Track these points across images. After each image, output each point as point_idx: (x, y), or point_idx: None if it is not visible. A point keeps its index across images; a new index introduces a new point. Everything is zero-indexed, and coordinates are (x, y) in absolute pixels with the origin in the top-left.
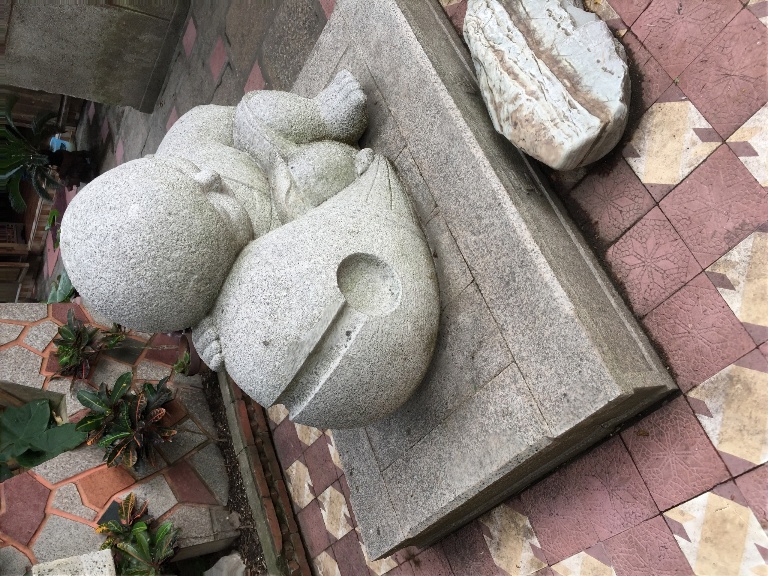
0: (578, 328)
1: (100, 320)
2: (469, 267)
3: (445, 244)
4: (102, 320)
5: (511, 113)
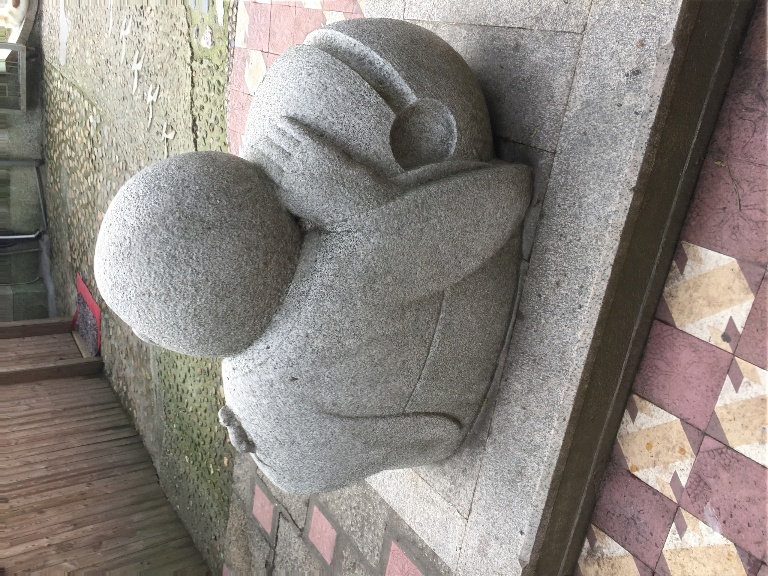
0: (366, 2)
1: None
2: None
3: None
4: None
5: None
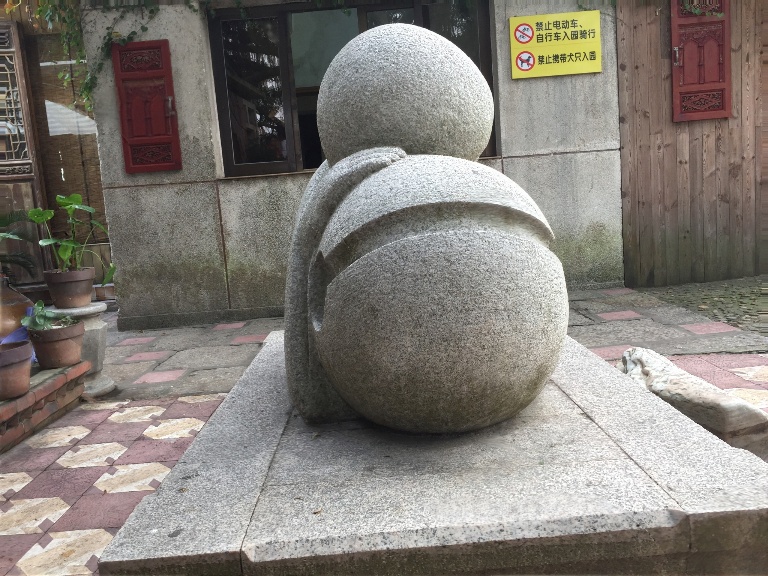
0: (755, 457)
1: None
2: (581, 407)
3: (550, 394)
4: None
5: (672, 379)
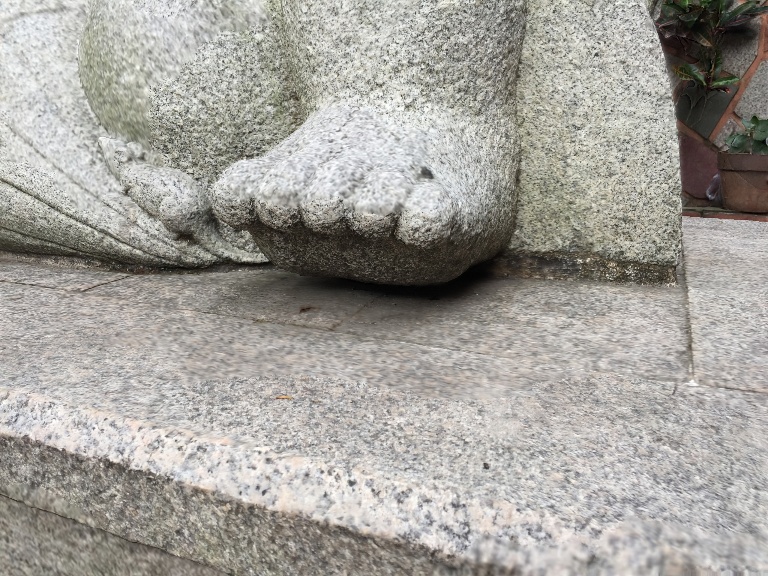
0: None
1: (767, 70)
2: None
3: None
4: (767, 73)
5: None
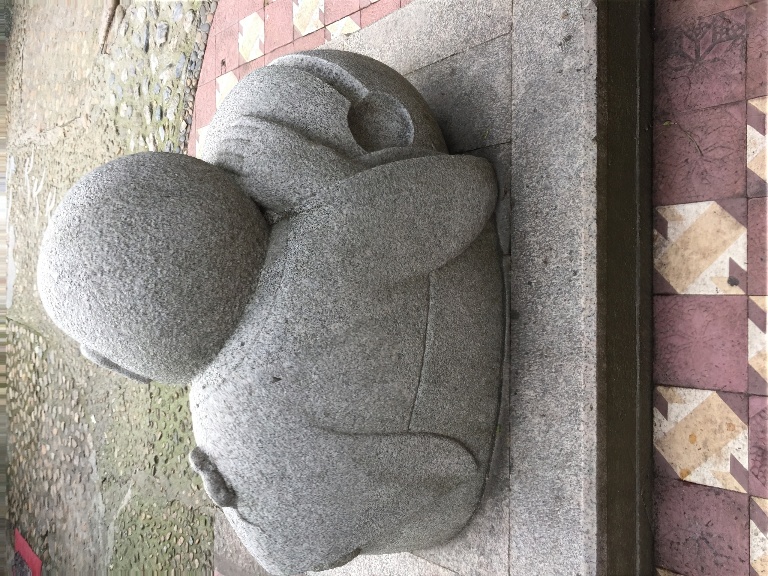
0: None
1: None
2: None
3: None
4: None
5: None
